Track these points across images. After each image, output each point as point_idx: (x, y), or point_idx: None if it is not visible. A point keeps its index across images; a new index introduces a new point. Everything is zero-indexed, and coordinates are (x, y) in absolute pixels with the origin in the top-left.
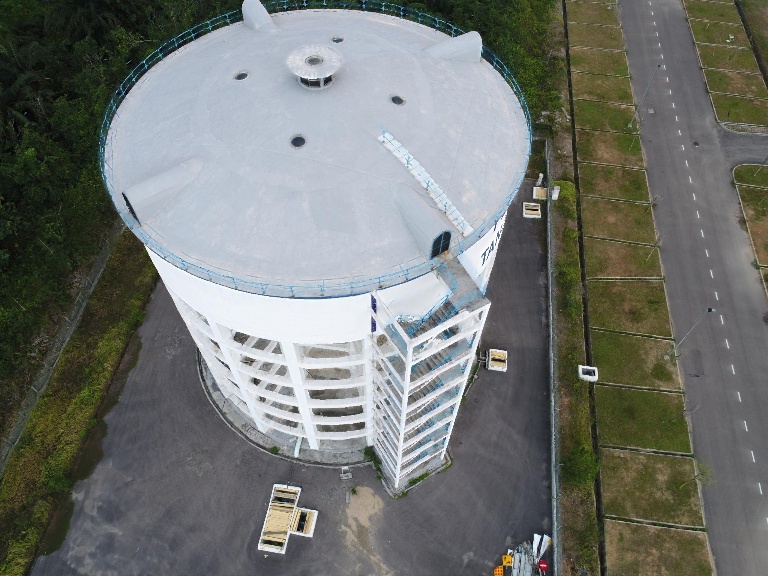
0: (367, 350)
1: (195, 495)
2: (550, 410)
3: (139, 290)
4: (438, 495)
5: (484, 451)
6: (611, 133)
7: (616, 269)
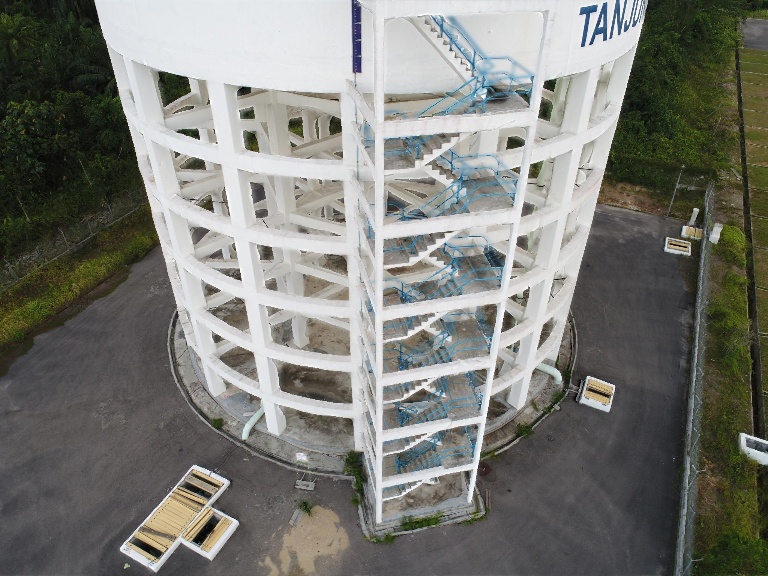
0: (347, 135)
1: (81, 450)
2: (681, 483)
3: None
4: (447, 559)
5: (548, 514)
6: None
7: None
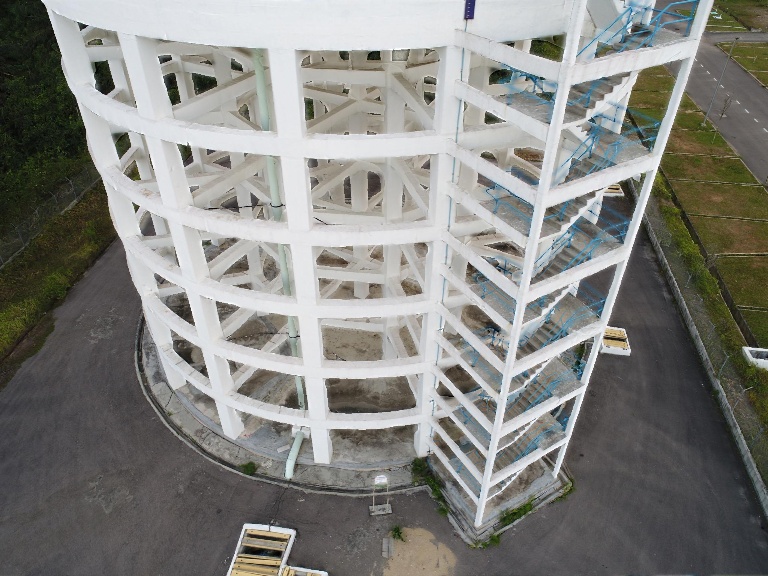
0: (448, 97)
1: (90, 547)
2: (720, 406)
3: (68, 267)
4: (559, 542)
5: (626, 467)
6: (683, 131)
7: (746, 245)
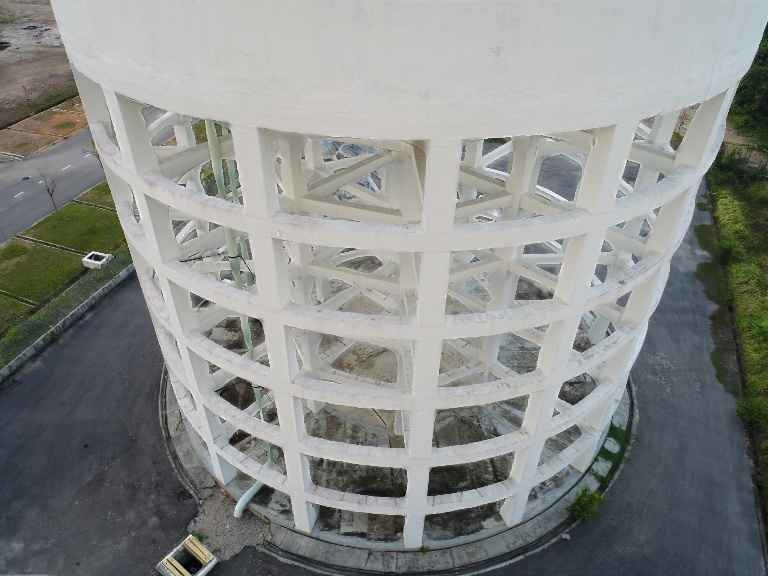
0: None
1: None
2: None
3: None
4: None
5: None
6: None
7: None
